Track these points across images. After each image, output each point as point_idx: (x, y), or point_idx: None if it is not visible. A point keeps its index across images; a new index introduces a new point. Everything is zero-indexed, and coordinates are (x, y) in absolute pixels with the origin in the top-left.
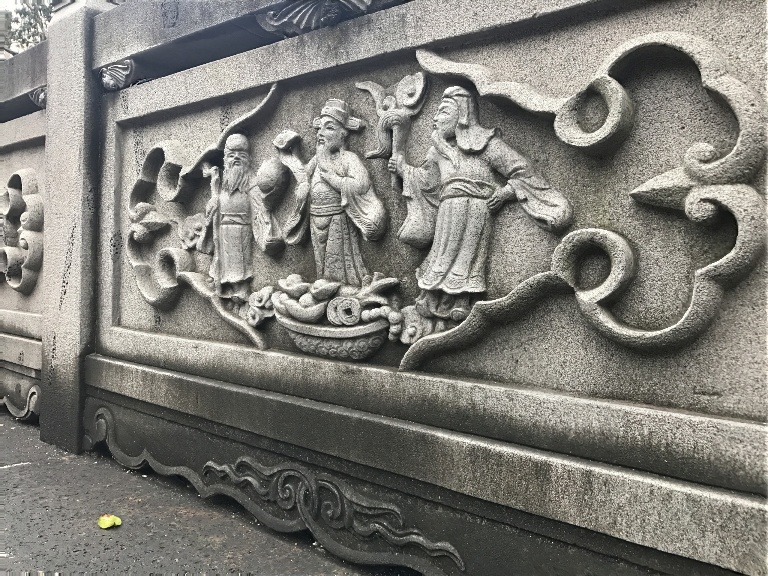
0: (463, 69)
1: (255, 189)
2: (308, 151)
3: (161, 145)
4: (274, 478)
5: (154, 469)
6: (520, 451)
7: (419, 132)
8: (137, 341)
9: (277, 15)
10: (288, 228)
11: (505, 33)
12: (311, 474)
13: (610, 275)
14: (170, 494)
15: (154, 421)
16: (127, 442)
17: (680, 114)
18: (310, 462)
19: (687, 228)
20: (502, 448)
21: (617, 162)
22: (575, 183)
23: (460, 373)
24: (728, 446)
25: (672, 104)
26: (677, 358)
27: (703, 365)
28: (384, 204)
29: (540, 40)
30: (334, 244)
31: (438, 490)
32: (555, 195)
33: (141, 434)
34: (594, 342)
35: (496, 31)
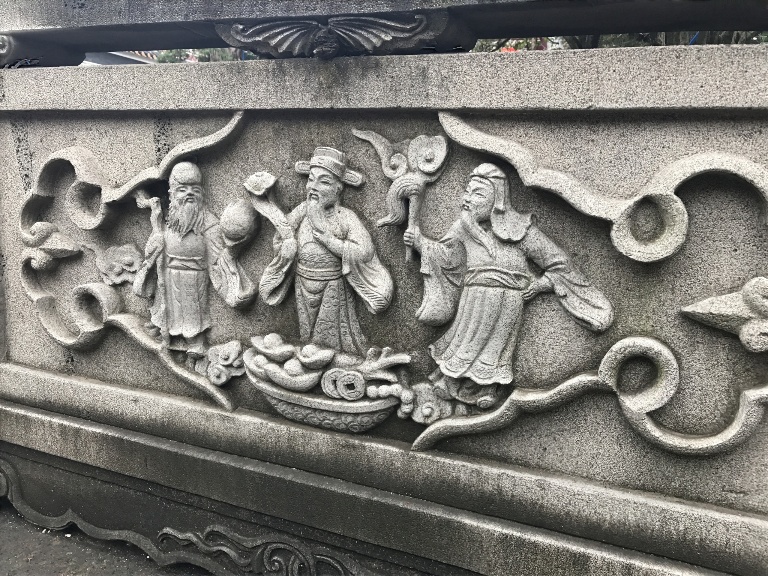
0: (502, 149)
1: (213, 230)
2: (286, 196)
3: (67, 156)
4: (258, 550)
5: (86, 532)
6: (556, 542)
7: (436, 200)
8: (43, 385)
9: (247, 30)
10: (269, 288)
11: (546, 113)
12: (306, 548)
13: (660, 388)
14: (112, 560)
15: (81, 480)
16: (42, 501)
17: (734, 236)
18: (305, 536)
19: (732, 346)
20: (537, 538)
21: (664, 271)
22: (618, 285)
23: (480, 455)
24: (758, 544)
25: (726, 225)
26: (711, 461)
27: (734, 468)
28: (390, 272)
29: (587, 129)
30: (330, 311)
31: (463, 571)
32: (598, 295)
33: (63, 494)
34: (630, 440)
35: (539, 111)
